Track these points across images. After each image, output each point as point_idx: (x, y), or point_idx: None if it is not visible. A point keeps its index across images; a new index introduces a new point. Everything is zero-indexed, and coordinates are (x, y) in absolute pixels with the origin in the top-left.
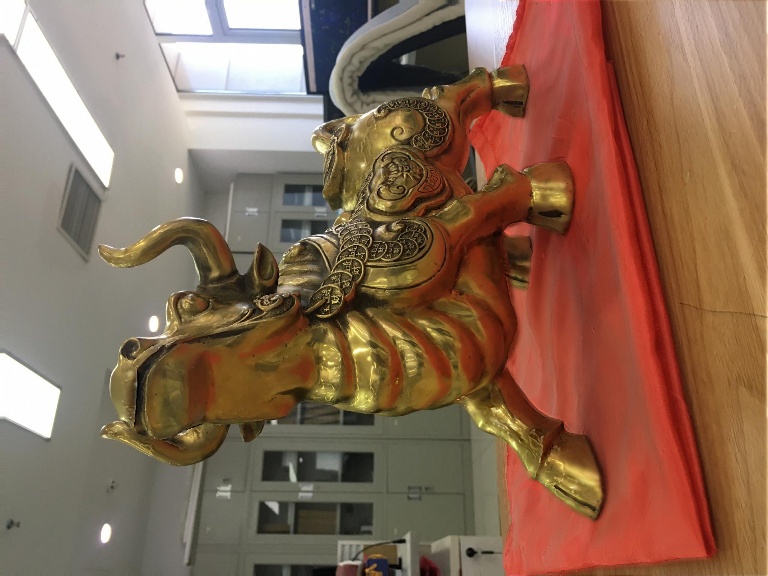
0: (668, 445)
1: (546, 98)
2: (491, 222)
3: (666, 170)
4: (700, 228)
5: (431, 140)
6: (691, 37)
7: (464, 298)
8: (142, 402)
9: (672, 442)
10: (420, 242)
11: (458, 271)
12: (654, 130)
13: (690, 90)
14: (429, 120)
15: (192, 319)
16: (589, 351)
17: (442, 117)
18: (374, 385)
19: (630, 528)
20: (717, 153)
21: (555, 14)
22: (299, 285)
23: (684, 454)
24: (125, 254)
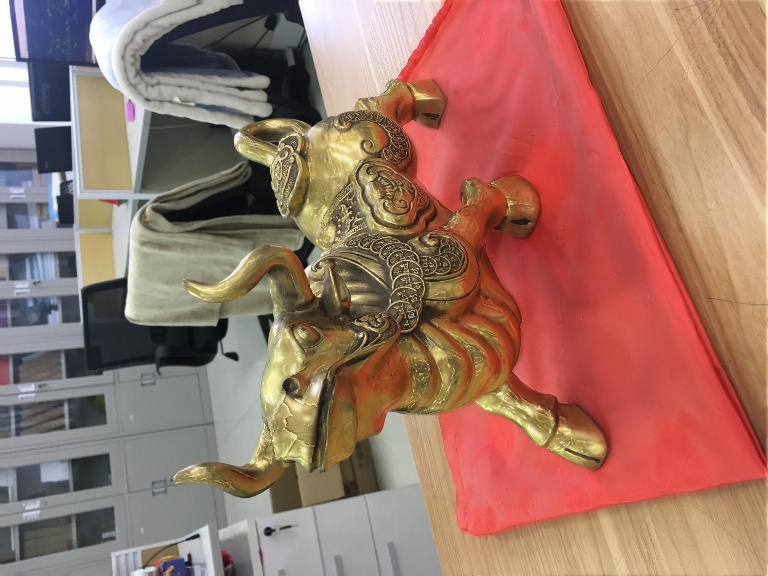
0: (723, 403)
1: (481, 116)
2: (485, 232)
3: (683, 197)
4: (732, 244)
5: (398, 153)
6: (712, 100)
7: (491, 302)
8: (320, 438)
9: (727, 401)
10: (459, 255)
11: (480, 278)
12: (663, 164)
13: (713, 140)
14: (391, 134)
15: (314, 349)
16: (573, 336)
17: (400, 131)
18: (452, 388)
19: (663, 470)
20: (752, 191)
21: (494, 45)
22: (353, 302)
23: (736, 408)
24: (223, 288)
